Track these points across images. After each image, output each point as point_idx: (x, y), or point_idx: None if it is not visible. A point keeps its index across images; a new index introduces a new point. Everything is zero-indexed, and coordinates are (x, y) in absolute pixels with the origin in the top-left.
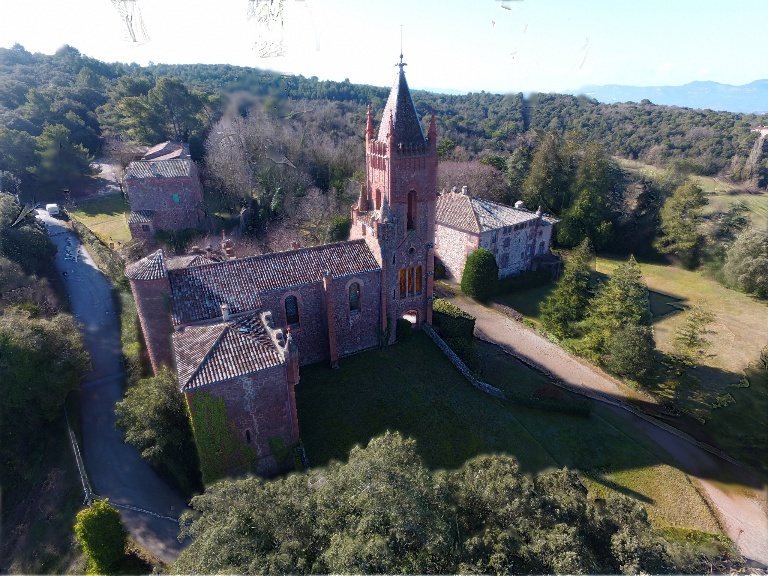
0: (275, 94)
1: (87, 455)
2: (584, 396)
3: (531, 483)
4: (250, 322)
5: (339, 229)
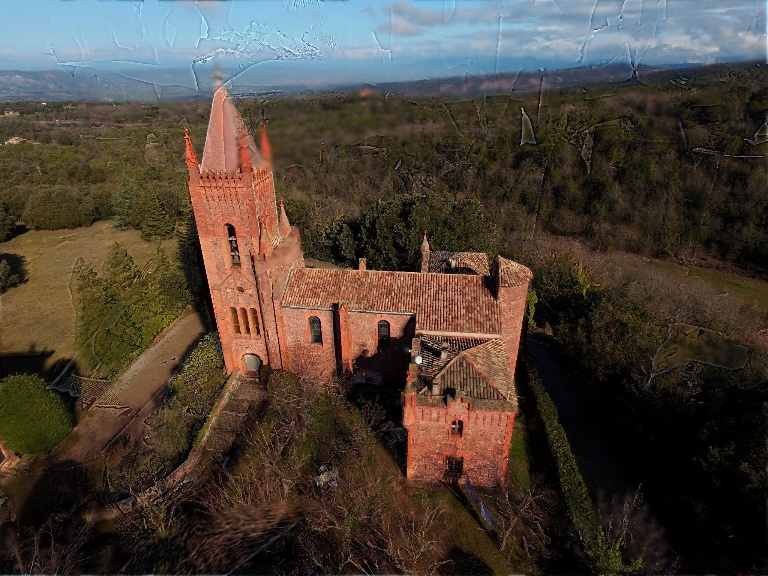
0: (307, 124)
1: (559, 366)
2: (213, 321)
3: None
4: (438, 265)
5: None
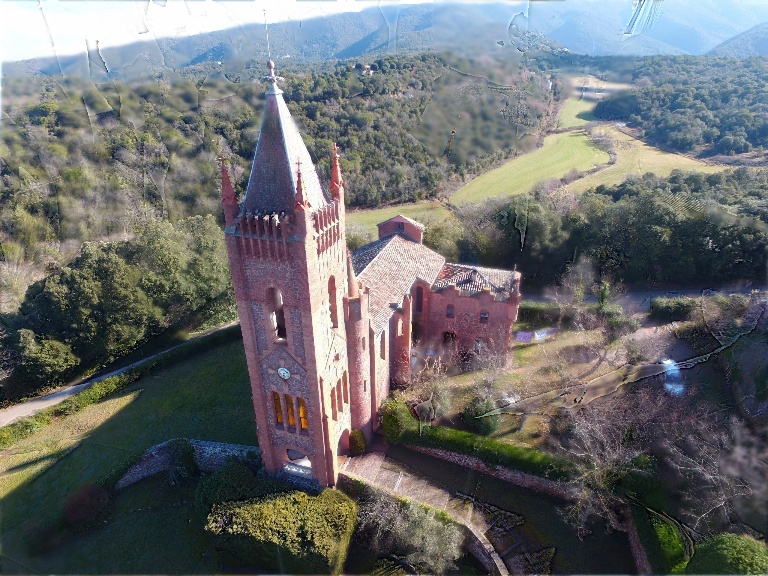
0: (474, 115)
1: None
2: None
3: (115, 412)
4: None
5: (709, 548)
